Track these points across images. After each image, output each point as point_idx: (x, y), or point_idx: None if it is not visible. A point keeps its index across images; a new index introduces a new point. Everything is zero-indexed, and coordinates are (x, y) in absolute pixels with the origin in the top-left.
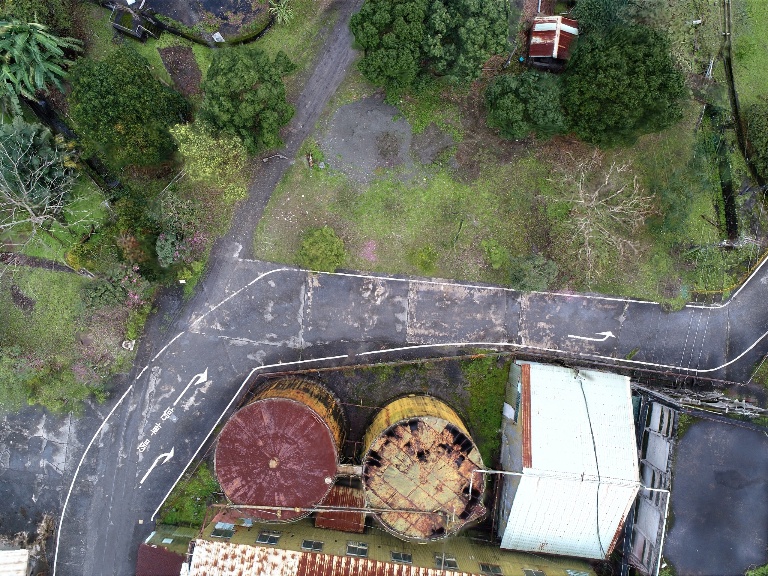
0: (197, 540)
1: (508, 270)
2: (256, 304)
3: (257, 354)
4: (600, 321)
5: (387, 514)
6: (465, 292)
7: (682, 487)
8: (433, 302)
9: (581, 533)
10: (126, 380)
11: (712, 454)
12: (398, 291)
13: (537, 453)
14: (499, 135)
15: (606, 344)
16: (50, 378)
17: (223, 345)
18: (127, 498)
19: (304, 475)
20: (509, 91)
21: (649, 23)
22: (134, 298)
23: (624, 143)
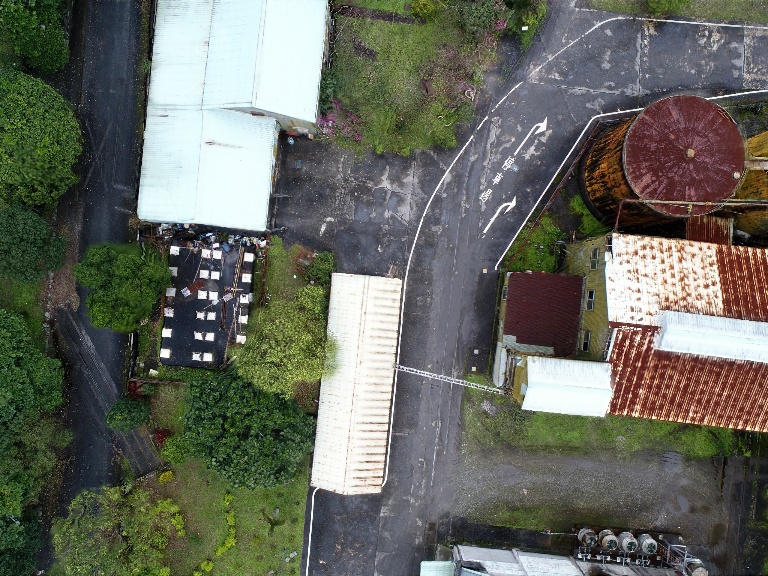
0: (613, 234)
1: None
2: (593, 53)
3: (596, 102)
4: None
5: None
6: None
7: None
8: None
9: None
10: (467, 131)
11: None
12: (734, 37)
13: None
14: None
15: None
16: (394, 128)
17: (562, 94)
18: (471, 248)
19: (715, 169)
20: None
21: None
22: (503, 26)
23: None
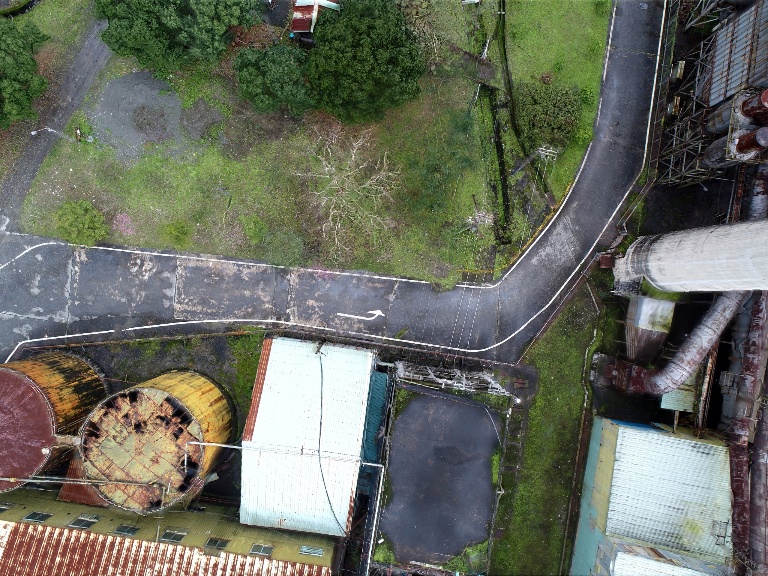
0: None
1: (277, 247)
2: (23, 278)
3: (23, 328)
4: (370, 299)
5: (105, 486)
6: (234, 268)
7: (401, 462)
8: (201, 278)
9: (315, 509)
10: None
11: (432, 429)
12: (166, 267)
13: (260, 427)
14: (268, 111)
15: (375, 323)
16: None
17: None
18: None
19: (20, 445)
20: (248, 64)
21: None
22: None
23: (372, 118)
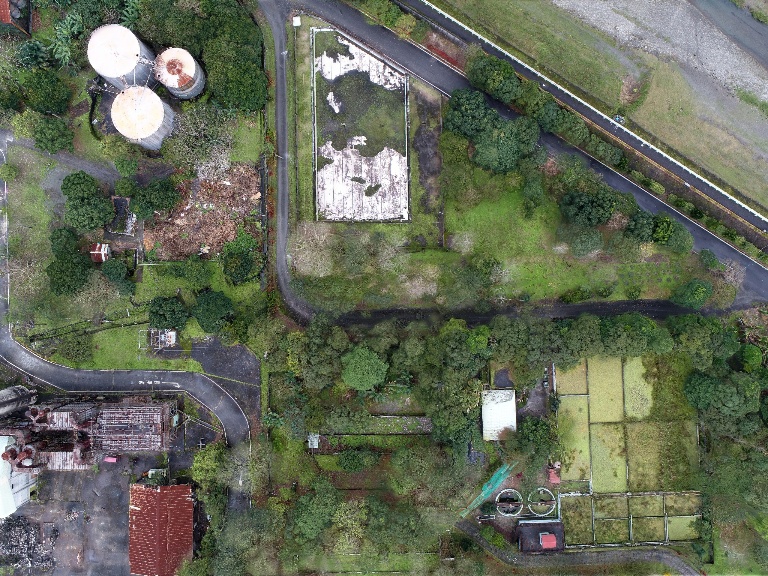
0: None
1: (15, 249)
2: None
3: None
4: None
5: None
6: (4, 233)
7: None
8: None
9: None
10: None
11: None
12: (1, 206)
13: None
14: None
15: None
16: None
17: None
18: None
19: None
20: None
21: (86, 278)
22: None
23: None
